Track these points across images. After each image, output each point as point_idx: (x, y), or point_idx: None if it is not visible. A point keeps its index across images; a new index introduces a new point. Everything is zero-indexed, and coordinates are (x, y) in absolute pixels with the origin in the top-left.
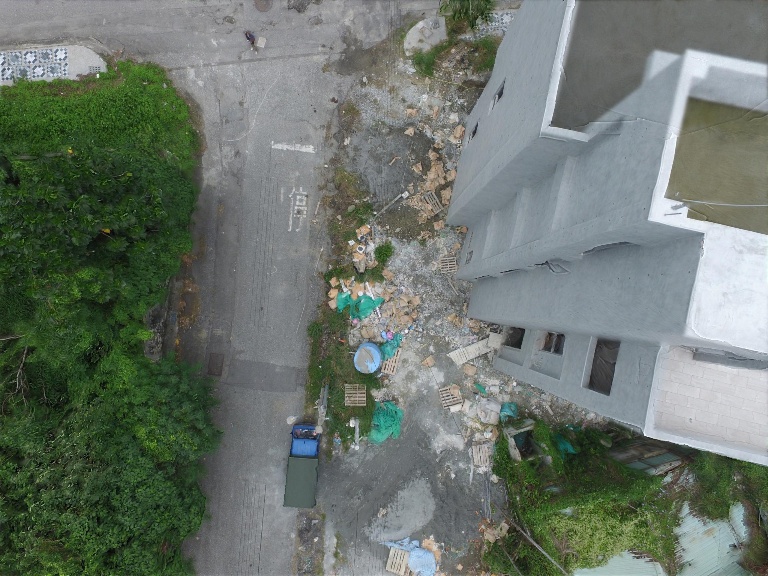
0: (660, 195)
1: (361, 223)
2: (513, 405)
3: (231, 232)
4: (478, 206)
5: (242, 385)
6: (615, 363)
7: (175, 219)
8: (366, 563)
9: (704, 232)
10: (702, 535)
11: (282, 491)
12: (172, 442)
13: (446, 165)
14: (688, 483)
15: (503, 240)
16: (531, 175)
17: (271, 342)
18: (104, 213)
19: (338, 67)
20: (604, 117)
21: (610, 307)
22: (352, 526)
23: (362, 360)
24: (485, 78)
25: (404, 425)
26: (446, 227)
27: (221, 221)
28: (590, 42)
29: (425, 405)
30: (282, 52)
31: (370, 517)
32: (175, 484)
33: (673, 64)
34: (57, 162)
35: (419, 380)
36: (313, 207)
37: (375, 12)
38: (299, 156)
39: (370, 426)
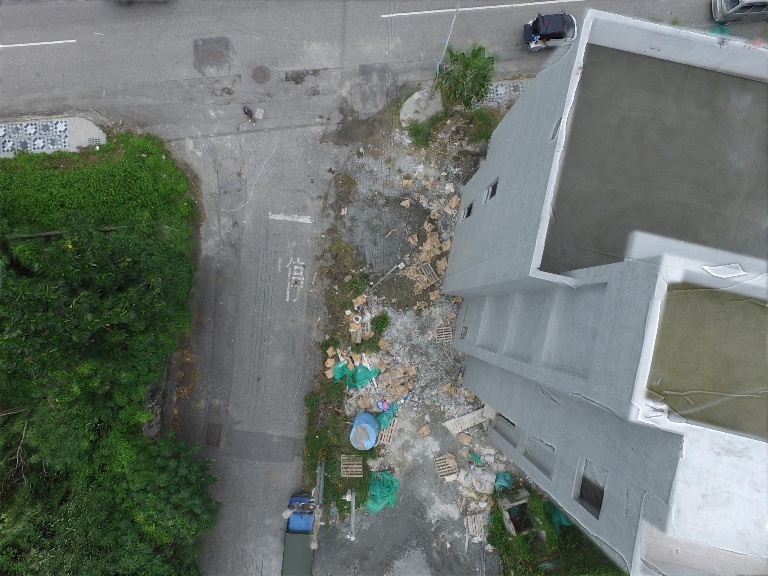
0: (642, 383)
1: (358, 293)
2: (508, 475)
3: (229, 302)
4: (472, 292)
5: (240, 455)
6: (604, 487)
7: (174, 299)
8: None
9: (683, 434)
10: None
11: (279, 561)
12: (170, 526)
13: (442, 235)
14: None
15: (496, 334)
16: (523, 290)
17: (268, 412)
18: (103, 309)
19: (335, 138)
20: (592, 261)
21: (598, 444)
22: None
23: (358, 438)
24: (480, 148)
25: (400, 494)
26: (442, 297)
27: (219, 291)
28: (579, 179)
29: (421, 474)
30: (280, 123)
31: None
32: (173, 567)
33: (660, 199)
34: (57, 256)
35: (415, 449)
36: (310, 277)
37: (372, 83)
38: (296, 226)
39: (366, 496)
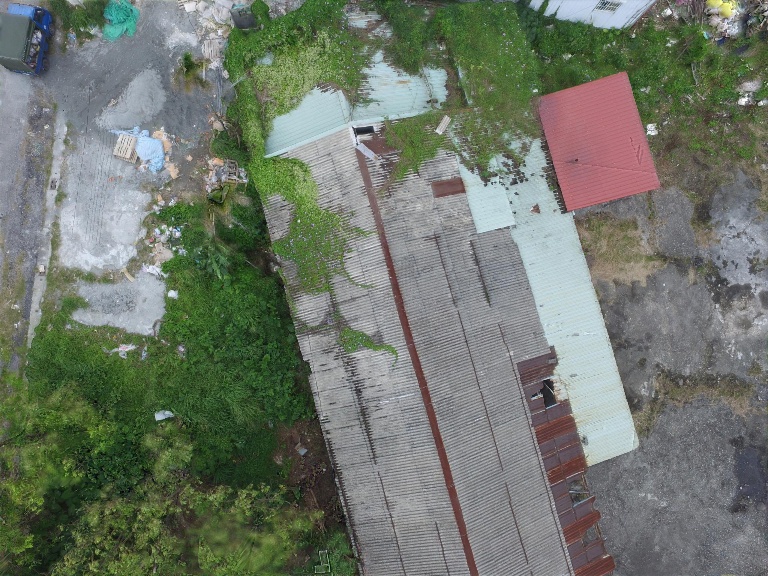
0: None
1: None
2: None
3: None
4: None
5: None
6: None
7: None
8: (95, 150)
9: None
10: (396, 84)
11: (12, 78)
12: None
13: None
14: (385, 35)
15: None
16: None
17: None
18: None
19: None
20: None
21: None
22: (83, 115)
23: None
24: None
25: (140, 24)
26: None
27: None
28: None
29: (162, 6)
30: None
31: (101, 107)
32: None
33: None
34: None
35: None
36: None
37: None
38: None
39: (104, 21)
